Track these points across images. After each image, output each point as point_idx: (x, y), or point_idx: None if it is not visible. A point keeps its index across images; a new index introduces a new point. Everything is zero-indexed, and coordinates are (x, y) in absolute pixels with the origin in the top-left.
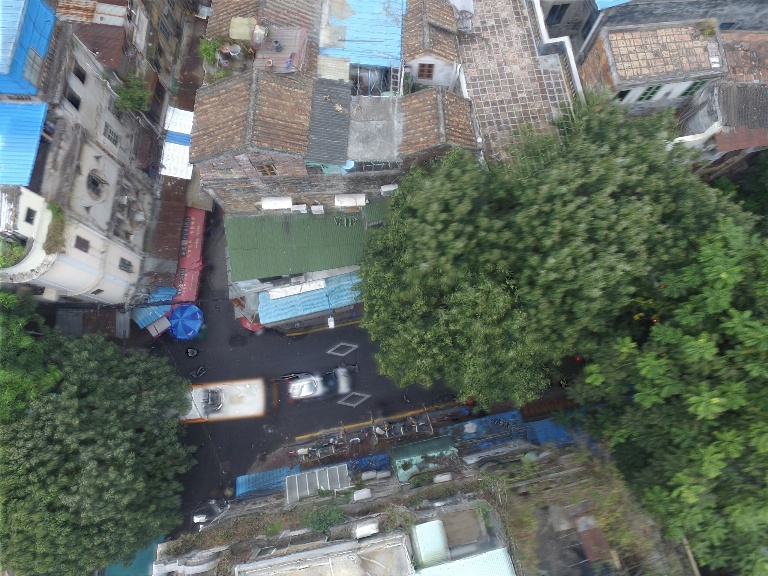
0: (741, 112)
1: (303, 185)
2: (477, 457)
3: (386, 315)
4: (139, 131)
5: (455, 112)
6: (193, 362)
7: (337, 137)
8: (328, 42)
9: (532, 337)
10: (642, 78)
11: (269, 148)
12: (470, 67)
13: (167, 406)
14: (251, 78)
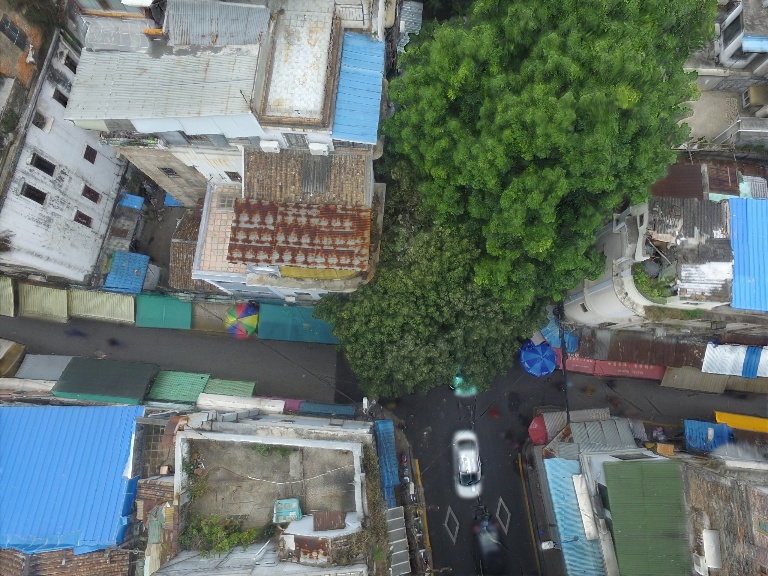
0: None
1: None
2: None
3: None
4: (767, 336)
5: None
6: None
7: None
8: None
9: None
10: None
11: None
12: None
13: None
14: None
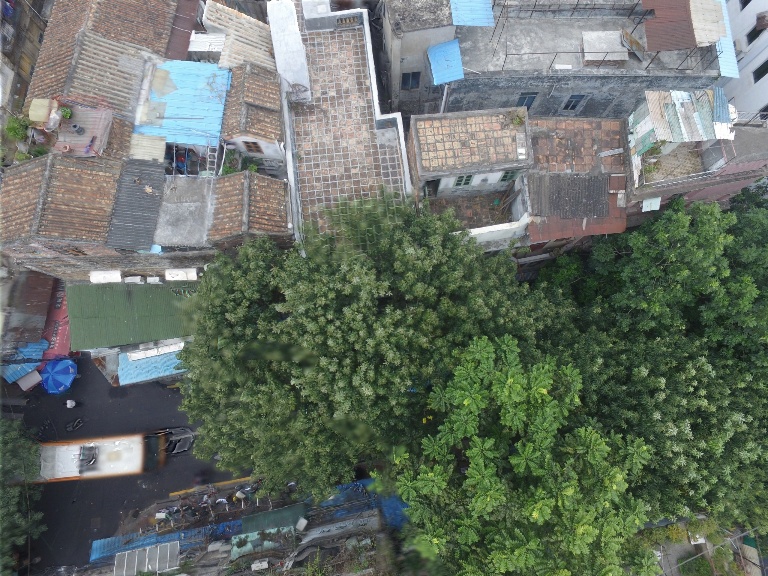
0: (552, 202)
1: (124, 263)
2: (320, 531)
3: (196, 401)
4: None
5: (265, 197)
6: (71, 414)
7: (144, 221)
8: (145, 120)
9: (326, 434)
10: (446, 169)
11: (59, 238)
12: (305, 140)
13: (12, 473)
14: (46, 164)
